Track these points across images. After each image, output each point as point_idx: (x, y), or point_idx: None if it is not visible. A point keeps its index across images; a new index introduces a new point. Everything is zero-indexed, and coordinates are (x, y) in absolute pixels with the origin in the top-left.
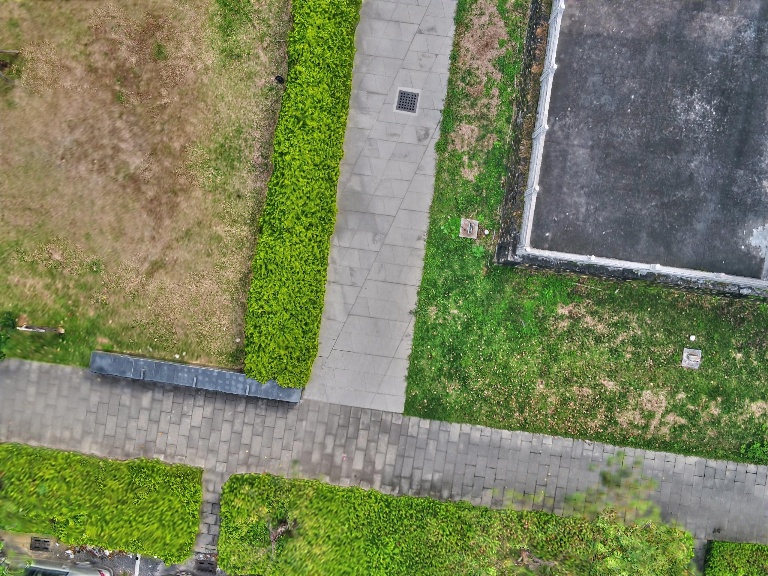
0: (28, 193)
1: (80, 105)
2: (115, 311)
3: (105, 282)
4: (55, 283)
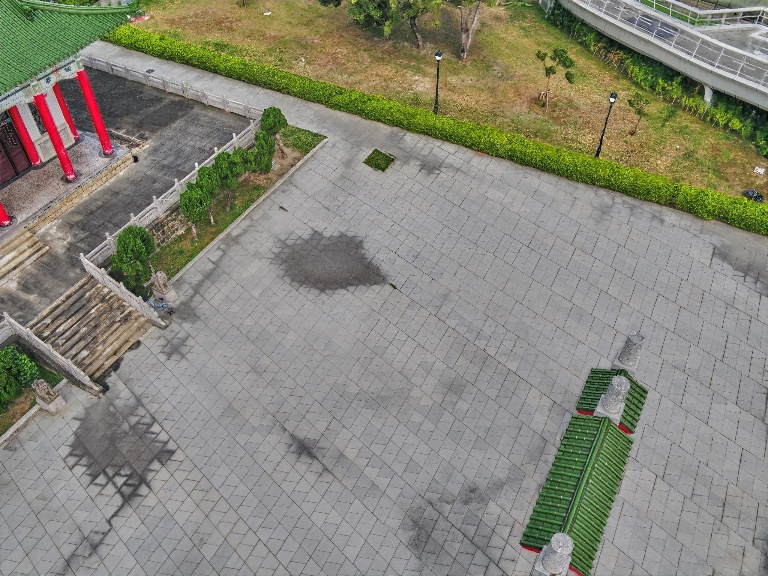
0: (201, 2)
1: (219, 14)
2: (147, 8)
3: (158, 8)
4: (168, 1)
